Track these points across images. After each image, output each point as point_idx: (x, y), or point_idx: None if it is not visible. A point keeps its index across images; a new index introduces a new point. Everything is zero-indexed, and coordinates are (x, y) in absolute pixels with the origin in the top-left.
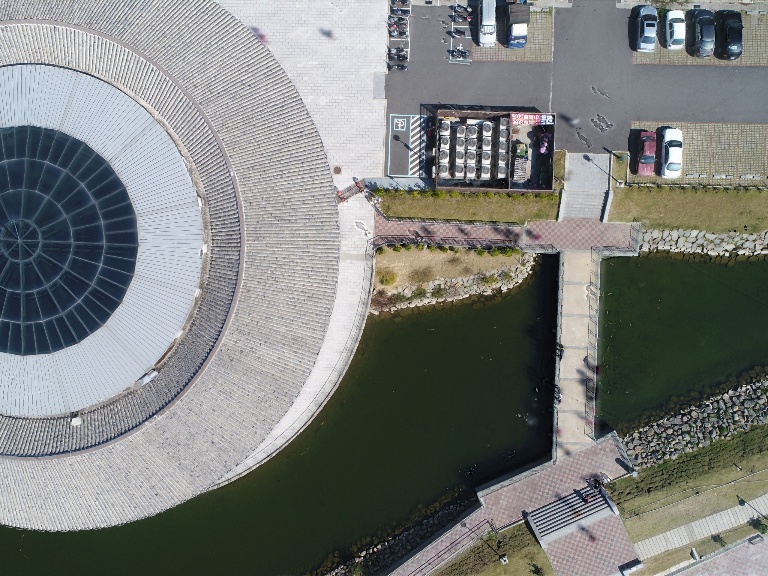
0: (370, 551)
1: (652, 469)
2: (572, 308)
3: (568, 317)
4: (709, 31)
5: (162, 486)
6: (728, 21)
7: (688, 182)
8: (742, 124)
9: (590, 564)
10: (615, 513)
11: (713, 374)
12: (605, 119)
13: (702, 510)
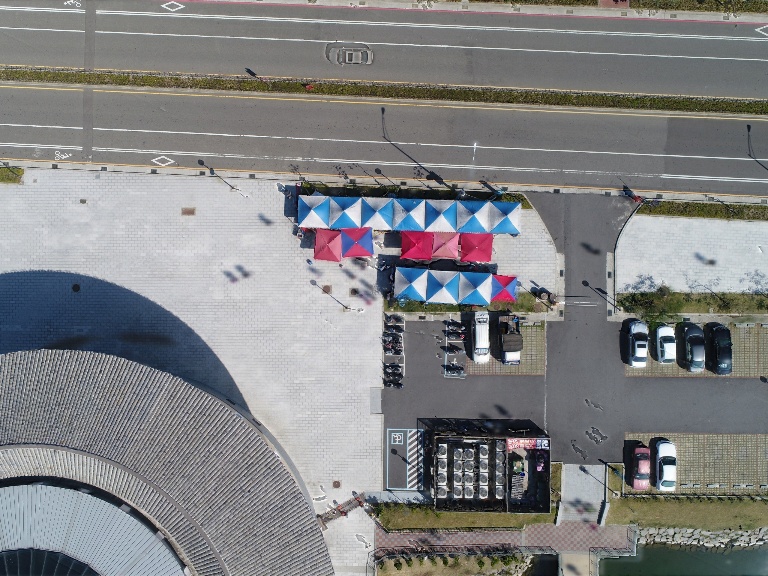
0: None
1: None
2: None
3: None
4: (699, 350)
5: None
6: (717, 339)
7: (683, 492)
8: (734, 434)
9: None
10: None
11: None
12: (599, 431)
13: None
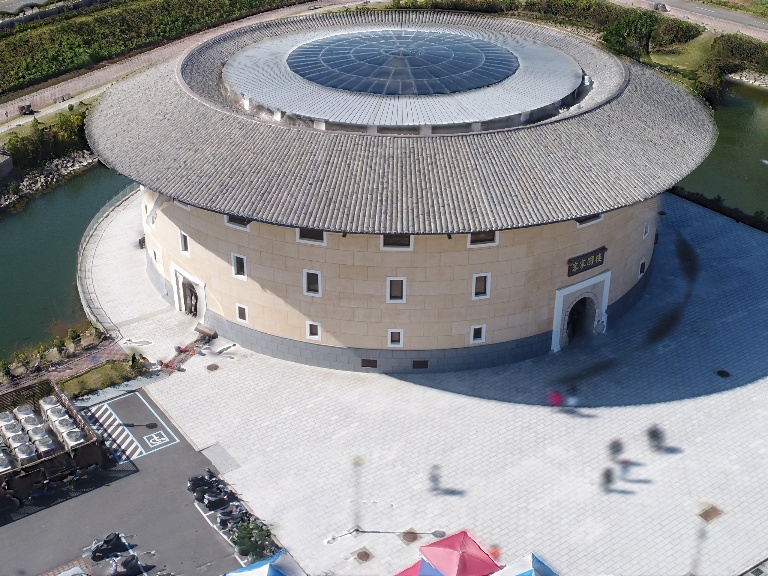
0: None
1: None
2: None
3: None
4: None
5: None
6: None
7: None
8: None
9: None
10: None
11: None
12: None
13: None
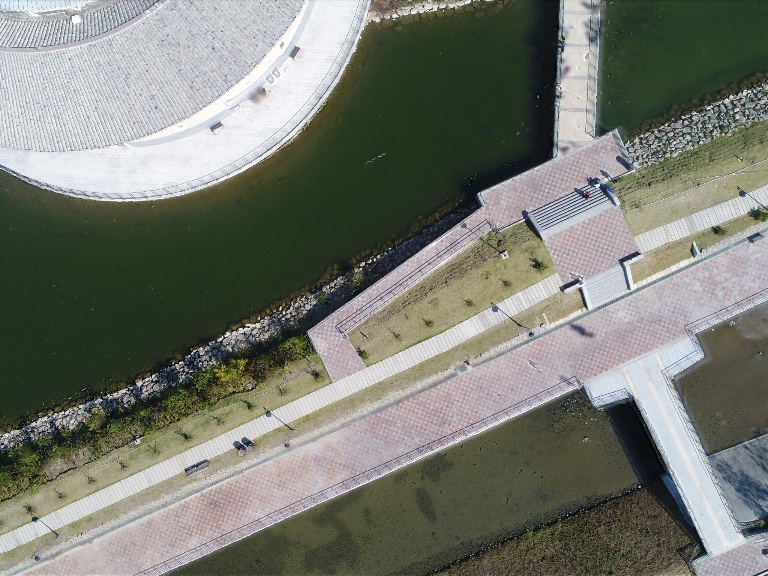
0: (369, 260)
1: (653, 167)
2: (574, 5)
3: (570, 14)
4: None
5: (162, 97)
6: None
7: None
8: None
9: (590, 257)
10: (616, 203)
11: (714, 83)
12: None
13: (703, 202)
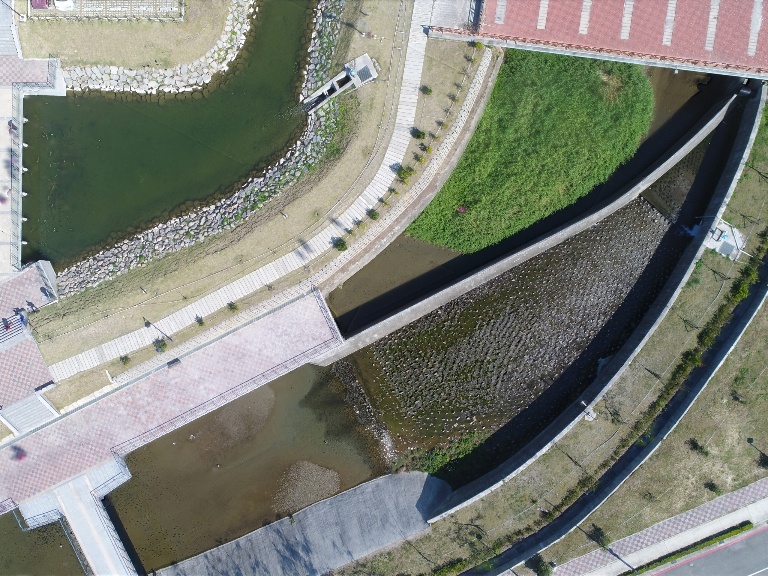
0: None
1: (74, 297)
2: None
3: None
4: None
5: None
6: None
7: (86, 15)
8: None
9: (8, 387)
10: None
11: (151, 210)
12: None
13: (111, 332)
